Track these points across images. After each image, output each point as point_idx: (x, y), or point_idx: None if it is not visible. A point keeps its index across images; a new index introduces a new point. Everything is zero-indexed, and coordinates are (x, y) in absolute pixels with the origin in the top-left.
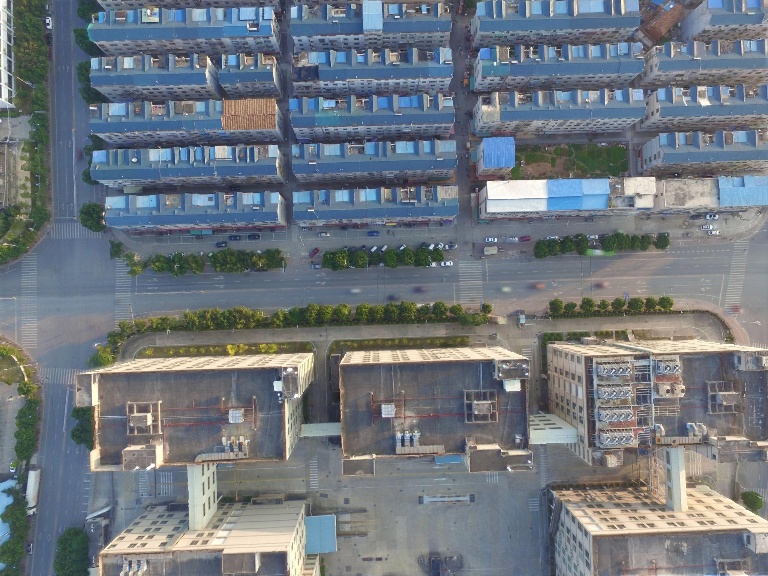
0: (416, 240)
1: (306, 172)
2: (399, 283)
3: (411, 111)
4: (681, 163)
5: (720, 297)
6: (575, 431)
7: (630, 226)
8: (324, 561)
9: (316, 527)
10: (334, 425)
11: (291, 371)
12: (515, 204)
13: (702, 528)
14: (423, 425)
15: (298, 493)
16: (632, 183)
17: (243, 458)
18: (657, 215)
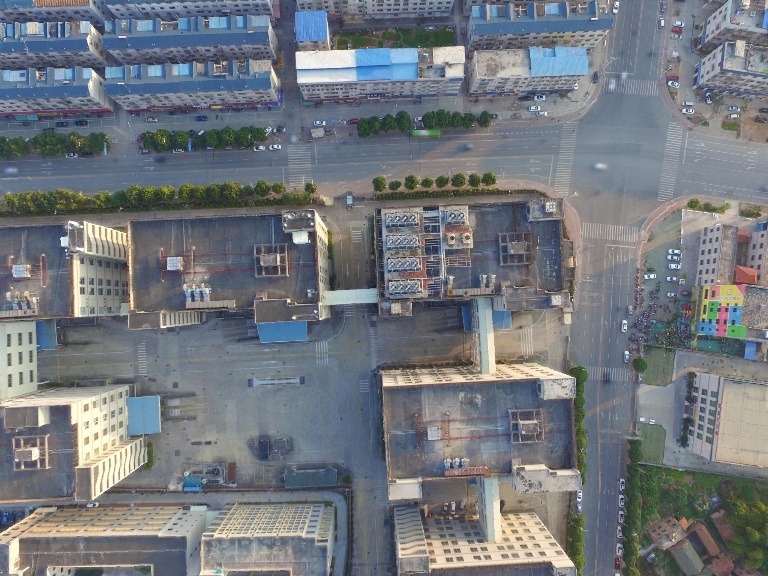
0: (245, 125)
1: (118, 47)
2: (228, 167)
3: None
4: (496, 37)
5: (550, 178)
6: (375, 290)
7: (459, 108)
8: (152, 446)
9: (139, 408)
10: None
11: (76, 225)
12: (325, 74)
13: (495, 379)
14: (214, 281)
15: (126, 378)
16: (441, 52)
17: (32, 315)
18: (485, 97)
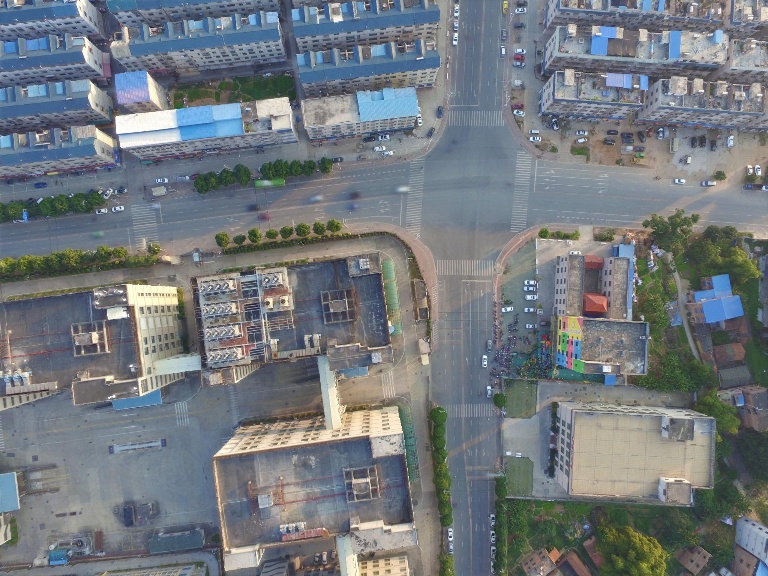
0: (86, 188)
1: None
2: (71, 233)
3: (38, 53)
4: (324, 83)
5: (400, 217)
6: None
7: (303, 154)
8: (16, 521)
9: None
10: None
11: None
12: (148, 137)
13: (327, 439)
14: (34, 363)
15: None
16: (265, 105)
17: None
18: (329, 141)
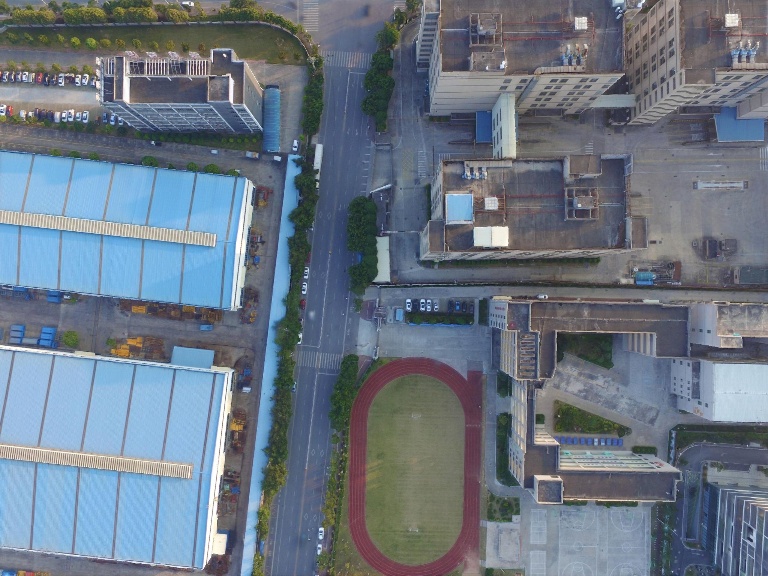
0: None
1: None
2: None
3: None
4: None
5: None
6: None
7: None
8: None
9: None
10: (622, 96)
11: None
12: None
13: None
14: None
15: None
16: None
17: (581, 72)
18: None
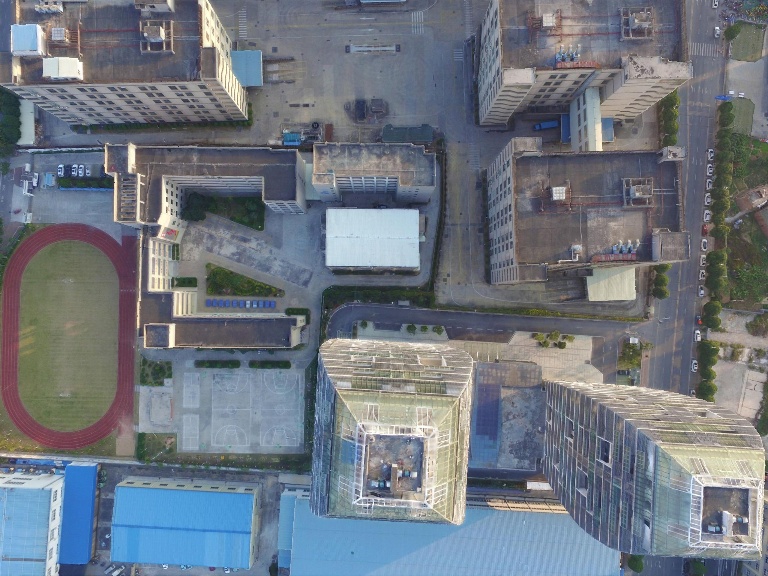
0: None
1: None
2: None
3: None
4: None
5: None
6: None
7: None
8: (252, 106)
9: (242, 60)
10: None
11: None
12: None
13: None
14: None
15: None
16: None
17: None
18: None
